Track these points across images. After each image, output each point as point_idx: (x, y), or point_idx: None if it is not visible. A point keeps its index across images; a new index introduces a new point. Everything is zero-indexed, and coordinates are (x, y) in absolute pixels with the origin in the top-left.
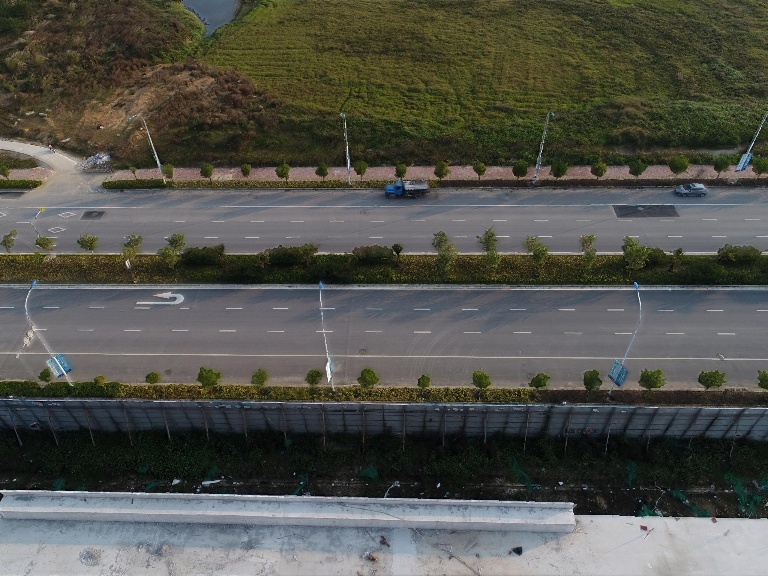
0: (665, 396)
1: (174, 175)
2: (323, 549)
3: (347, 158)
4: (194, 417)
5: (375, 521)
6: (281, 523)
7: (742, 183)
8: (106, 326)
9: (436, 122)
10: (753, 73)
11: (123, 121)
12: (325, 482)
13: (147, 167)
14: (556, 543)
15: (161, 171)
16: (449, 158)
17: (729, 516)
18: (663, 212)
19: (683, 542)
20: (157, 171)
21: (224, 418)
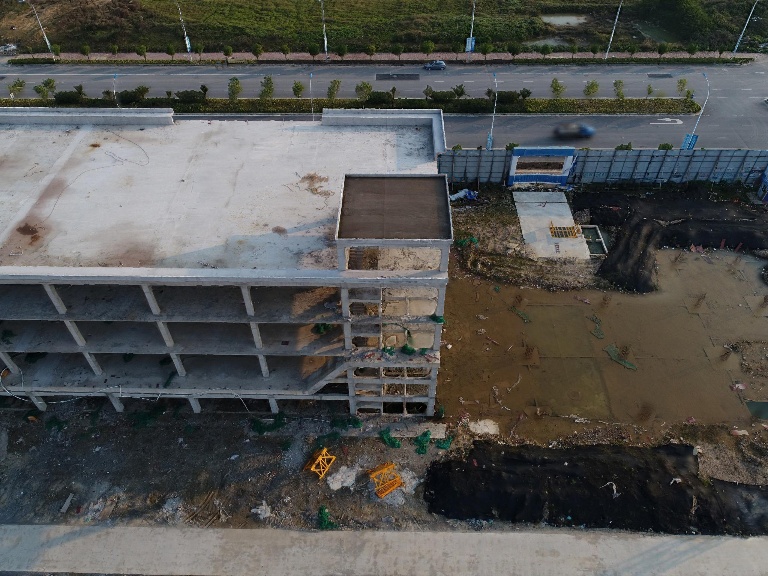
0: None
1: (63, 56)
2: (46, 130)
3: (185, 39)
4: None
5: (73, 118)
6: (28, 122)
7: (475, 62)
8: None
9: (273, 28)
10: (526, 0)
11: (32, 25)
12: None
13: (44, 52)
14: (163, 127)
15: (50, 49)
16: (271, 48)
17: None
18: (409, 78)
19: None
20: (51, 54)
21: None
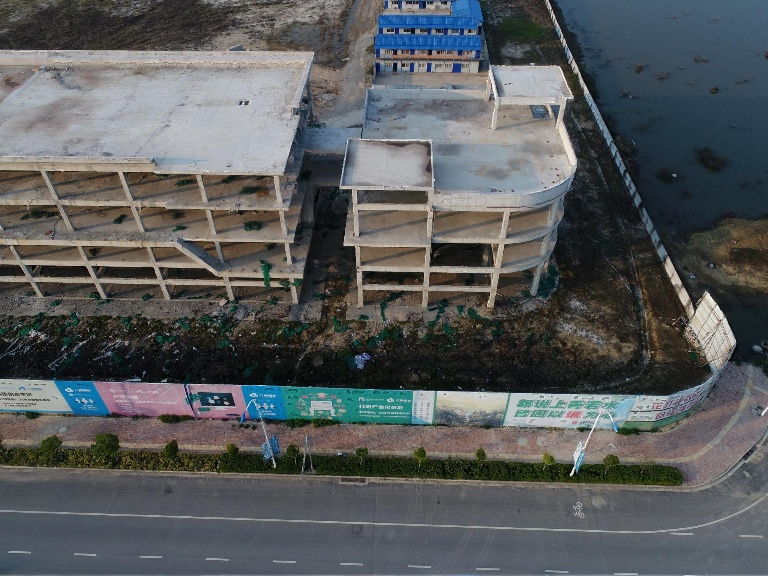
0: None
1: None
2: None
3: None
4: (125, 398)
5: None
6: None
7: None
8: (256, 568)
9: None
10: None
11: None
12: (35, 379)
13: None
14: None
15: None
16: None
17: None
18: None
19: None
20: None
21: (96, 399)
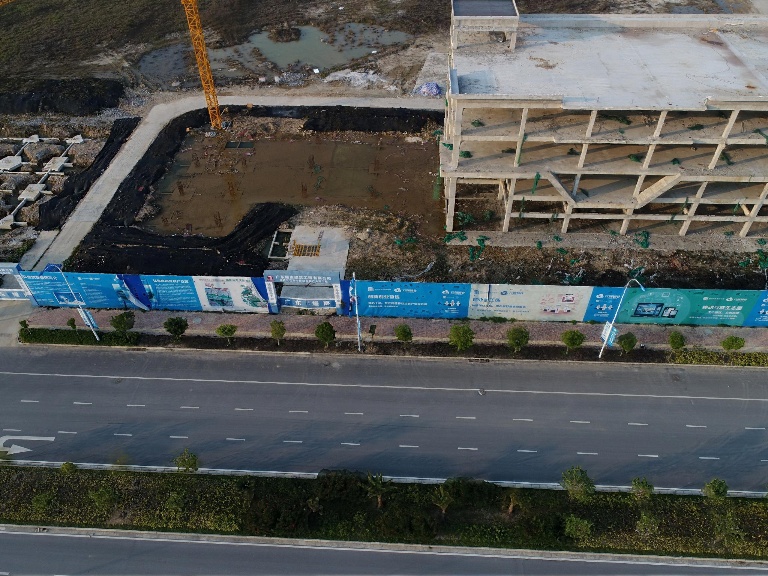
0: (550, 350)
1: None
2: None
3: None
4: None
5: None
6: None
7: None
8: None
9: None
10: None
11: None
12: None
13: None
14: None
15: None
16: None
17: (518, 279)
18: None
19: (652, 101)
20: None
21: None
